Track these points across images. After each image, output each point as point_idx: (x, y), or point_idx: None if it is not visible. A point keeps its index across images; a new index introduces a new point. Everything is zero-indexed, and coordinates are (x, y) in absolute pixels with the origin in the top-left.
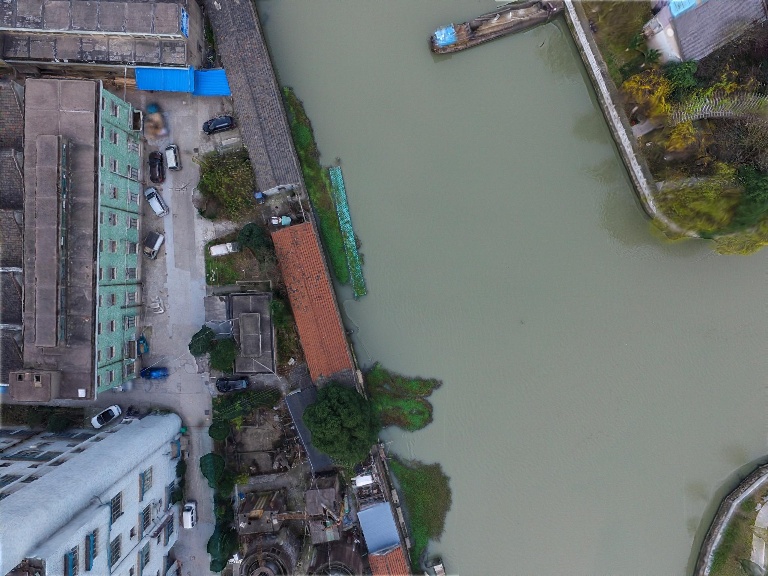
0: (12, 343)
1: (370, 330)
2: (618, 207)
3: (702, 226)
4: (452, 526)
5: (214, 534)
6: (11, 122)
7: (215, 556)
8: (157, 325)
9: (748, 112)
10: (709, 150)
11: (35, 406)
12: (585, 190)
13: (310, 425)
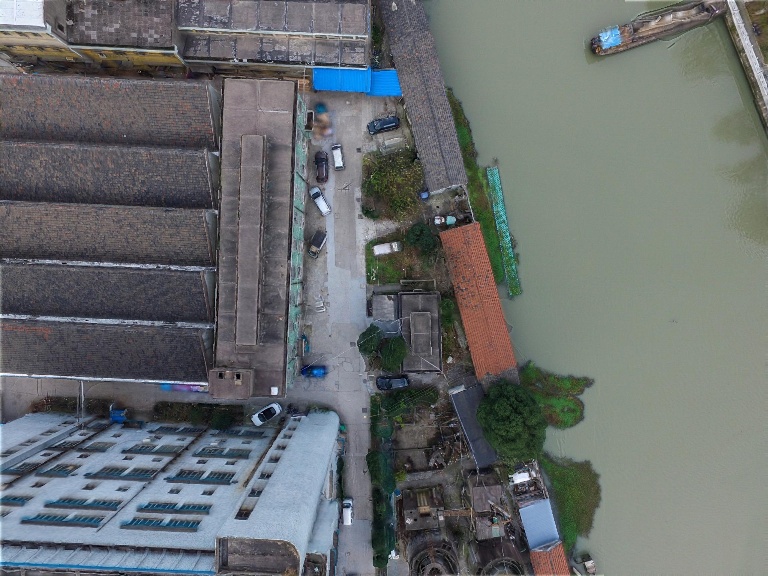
0: (198, 341)
1: (518, 329)
2: (756, 208)
3: None
4: (600, 522)
5: (378, 530)
6: (198, 122)
7: (378, 552)
8: (317, 323)
9: None
10: None
11: (194, 404)
12: (717, 191)
13: (489, 423)
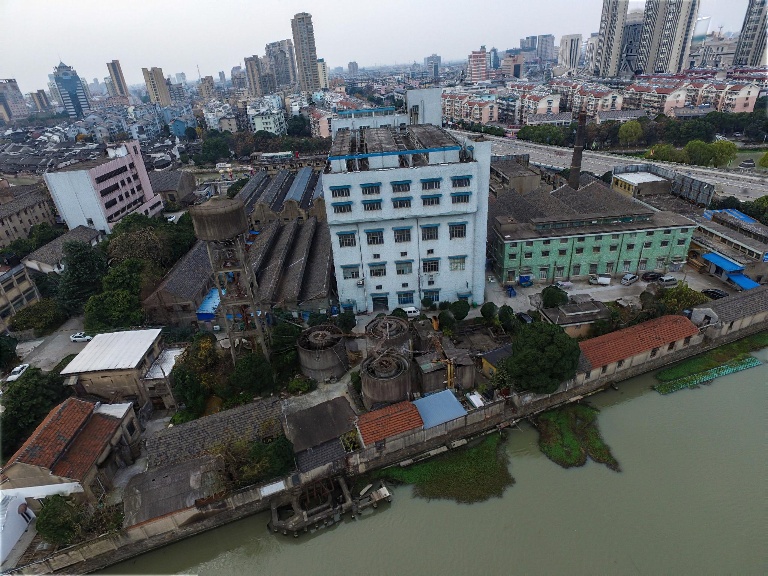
0: None
1: None
2: None
3: None
4: (436, 511)
5: None
6: None
7: None
8: None
9: None
10: None
11: None
12: None
13: None
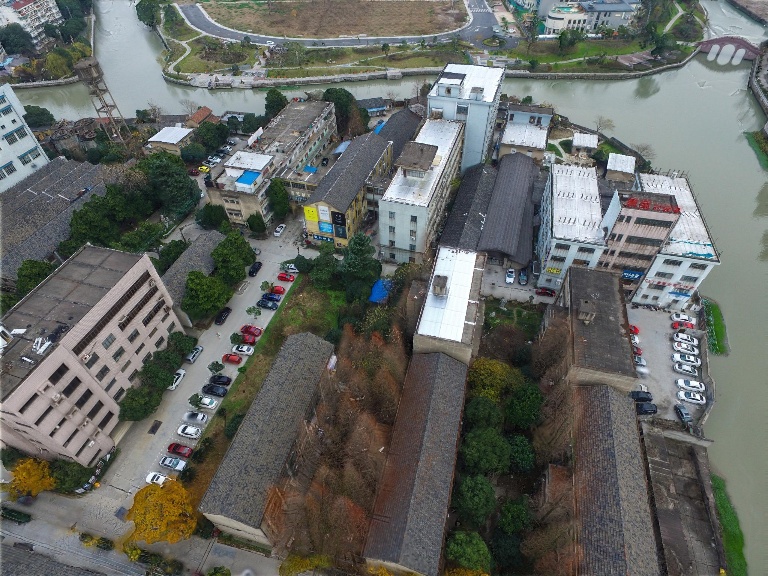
0: None
1: None
2: (70, 101)
3: (61, 61)
4: None
5: None
6: None
7: None
8: None
9: None
10: None
11: None
12: None
13: None
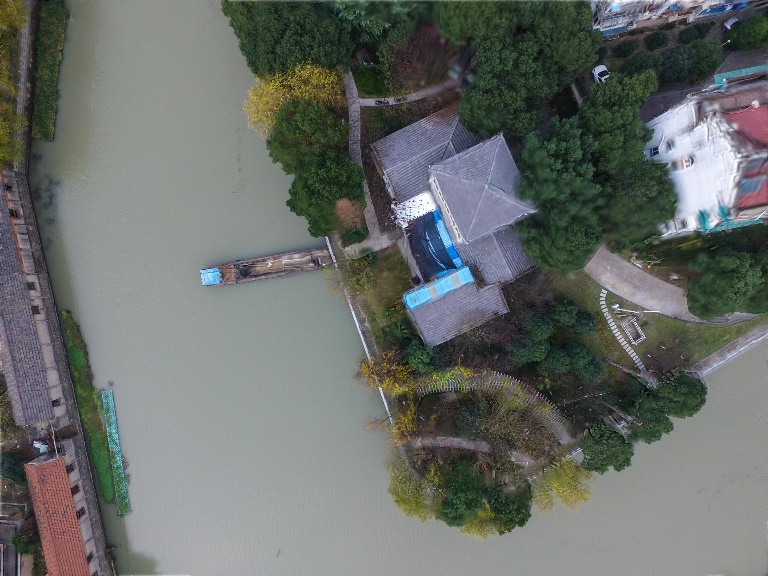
0: None
1: (140, 540)
2: None
3: None
4: None
5: None
6: None
7: None
8: None
9: (493, 390)
10: (425, 448)
11: None
12: None
13: None
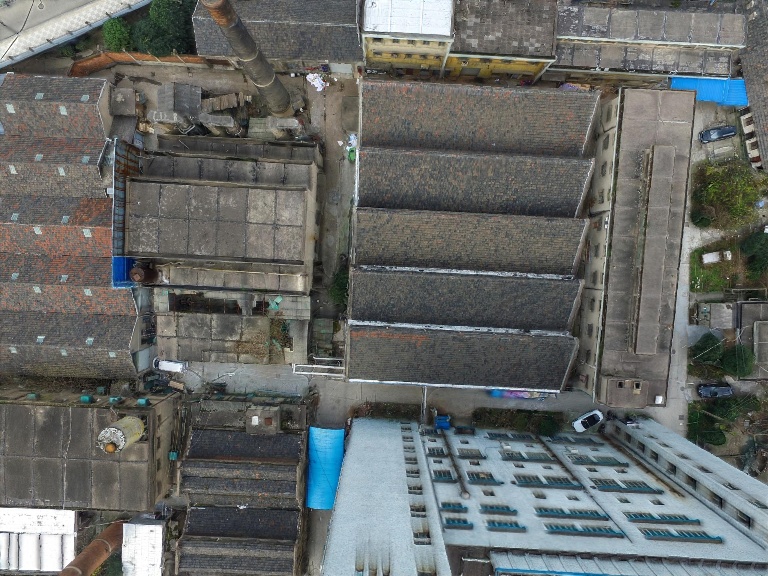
0: (571, 349)
1: None
2: None
3: None
4: None
5: None
6: (575, 131)
7: None
8: None
9: None
10: None
11: (514, 410)
12: None
13: None
